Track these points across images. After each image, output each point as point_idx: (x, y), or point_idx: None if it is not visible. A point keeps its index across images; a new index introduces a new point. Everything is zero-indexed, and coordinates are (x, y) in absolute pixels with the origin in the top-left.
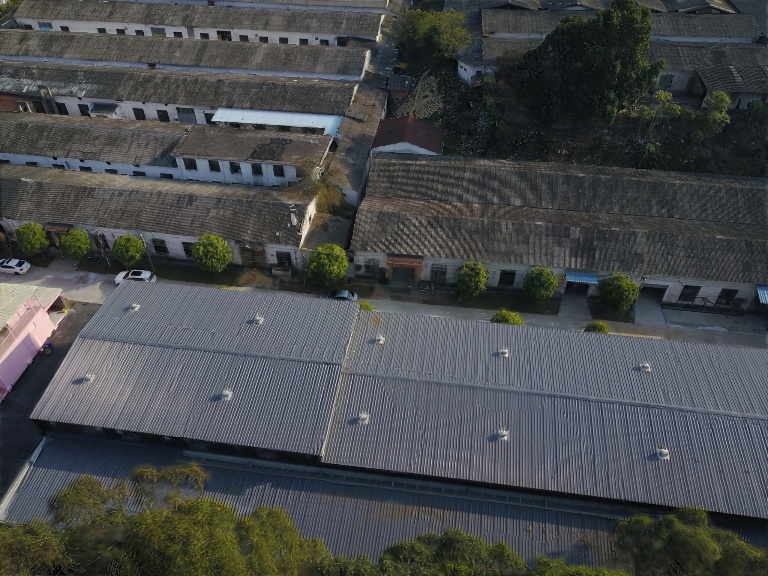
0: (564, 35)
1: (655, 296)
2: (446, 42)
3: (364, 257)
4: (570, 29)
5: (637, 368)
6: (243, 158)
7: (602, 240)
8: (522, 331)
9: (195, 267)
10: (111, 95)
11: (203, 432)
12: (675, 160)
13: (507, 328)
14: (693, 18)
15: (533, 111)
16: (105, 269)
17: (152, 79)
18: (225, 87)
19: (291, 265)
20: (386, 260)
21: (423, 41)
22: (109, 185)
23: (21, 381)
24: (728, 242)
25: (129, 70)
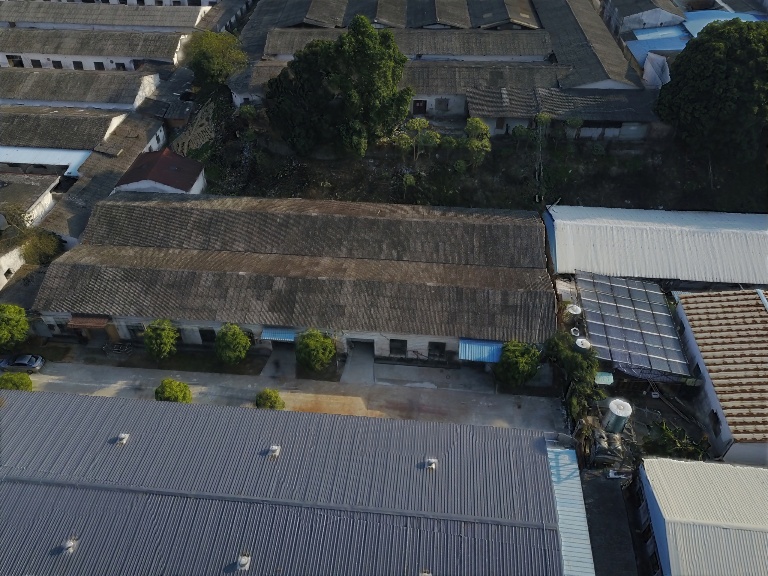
0: (301, 62)
1: (368, 350)
2: (217, 67)
3: (52, 317)
4: (307, 56)
5: (265, 451)
6: None
7: (305, 291)
8: (160, 408)
9: None
10: None
11: None
12: (440, 191)
13: (145, 405)
14: (486, 35)
15: None
16: None
17: None
18: None
19: None
20: None
21: (193, 66)
22: None
23: None
24: (438, 290)
25: None
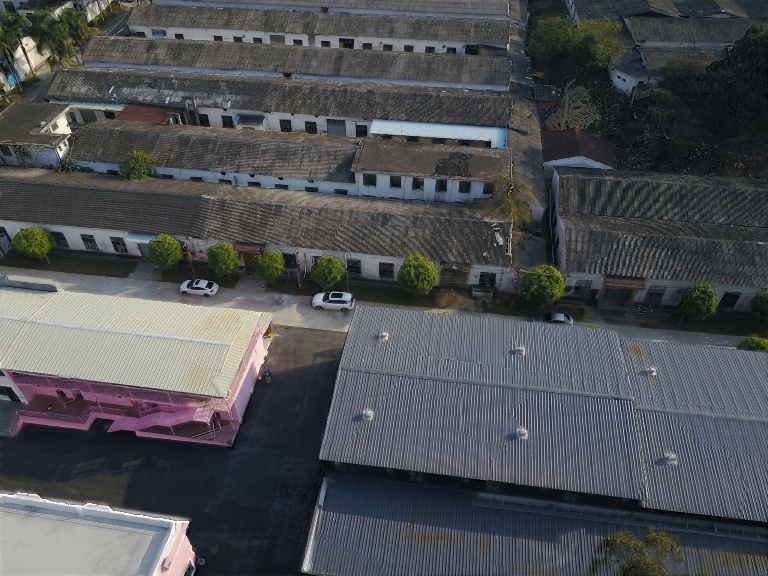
0: (758, 46)
1: None
2: (602, 51)
3: (577, 278)
4: (764, 40)
5: None
6: (428, 174)
7: None
8: None
9: (388, 288)
10: (258, 106)
11: (512, 475)
12: None
13: None
14: None
15: (712, 124)
16: (296, 290)
17: (299, 90)
18: (377, 98)
19: (493, 286)
20: (601, 282)
21: (578, 50)
22: (294, 202)
23: (249, 412)
24: None
25: (270, 80)
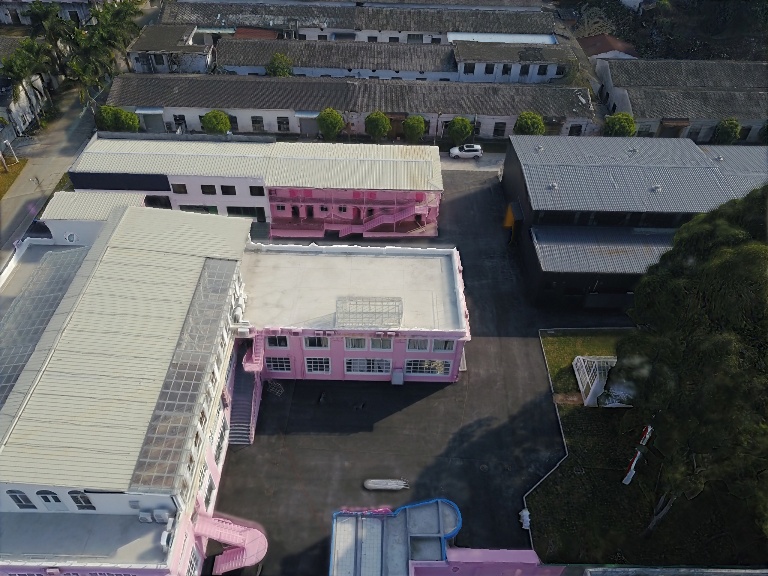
0: None
1: None
2: None
3: (640, 124)
4: None
5: None
6: (516, 60)
7: None
8: None
9: (500, 144)
10: (351, 25)
11: (659, 208)
12: None
13: None
14: None
15: (705, 24)
16: None
17: (381, 12)
18: (446, 16)
19: None
20: (657, 125)
21: None
22: (420, 84)
23: (439, 217)
24: None
25: None
